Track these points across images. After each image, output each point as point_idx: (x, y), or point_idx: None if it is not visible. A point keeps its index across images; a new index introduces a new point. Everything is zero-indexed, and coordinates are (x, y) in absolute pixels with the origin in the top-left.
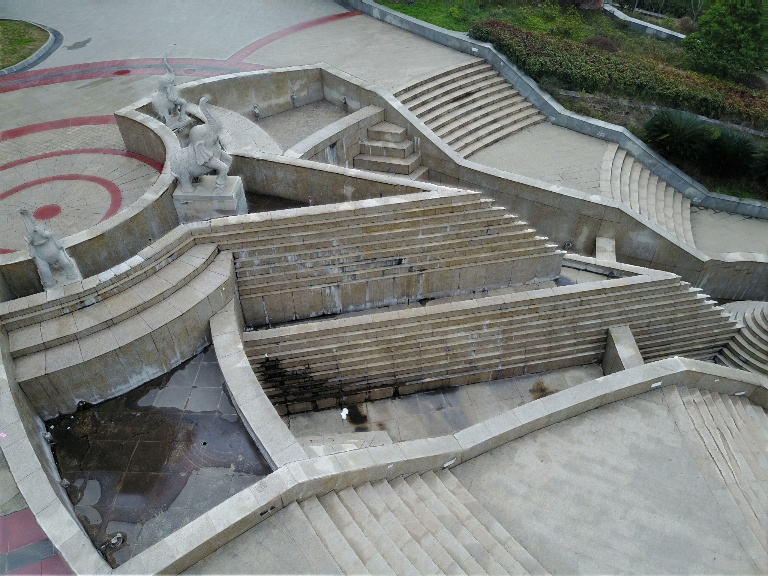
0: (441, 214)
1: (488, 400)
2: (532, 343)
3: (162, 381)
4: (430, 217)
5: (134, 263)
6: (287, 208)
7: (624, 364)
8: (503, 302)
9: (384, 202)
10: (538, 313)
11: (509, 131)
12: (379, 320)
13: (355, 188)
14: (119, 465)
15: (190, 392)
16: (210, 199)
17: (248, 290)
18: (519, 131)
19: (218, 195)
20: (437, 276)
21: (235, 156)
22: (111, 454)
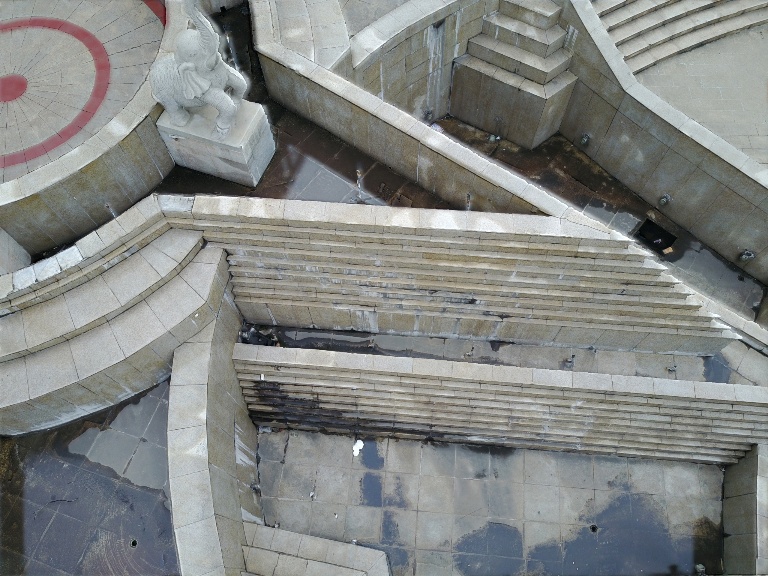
0: (555, 257)
1: (548, 482)
2: (635, 434)
3: (106, 417)
4: (536, 259)
5: (67, 262)
6: (332, 156)
7: (759, 515)
8: (611, 389)
9: (466, 225)
10: (659, 409)
11: (728, 29)
12: (422, 372)
13: (434, 164)
14: (25, 545)
15: (136, 447)
16: (209, 143)
17: (246, 293)
18: (744, 30)
19: (220, 141)
20: (524, 327)
21: (266, 57)
22: (20, 523)
